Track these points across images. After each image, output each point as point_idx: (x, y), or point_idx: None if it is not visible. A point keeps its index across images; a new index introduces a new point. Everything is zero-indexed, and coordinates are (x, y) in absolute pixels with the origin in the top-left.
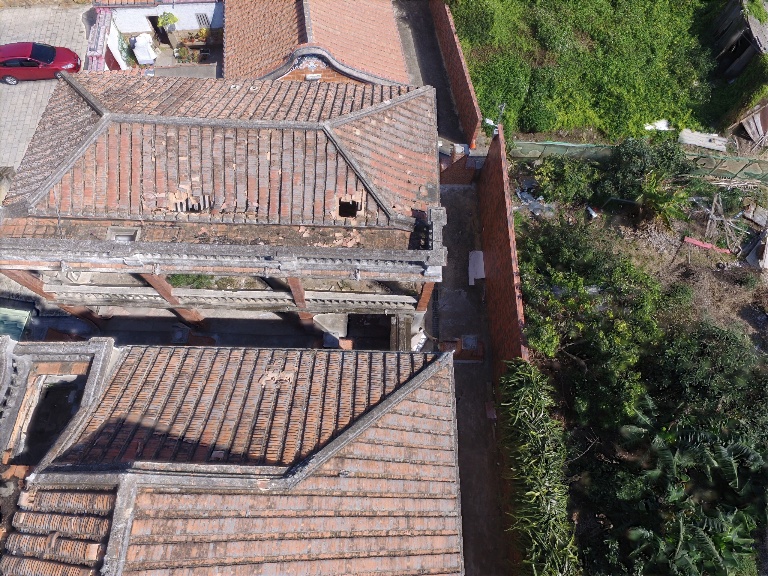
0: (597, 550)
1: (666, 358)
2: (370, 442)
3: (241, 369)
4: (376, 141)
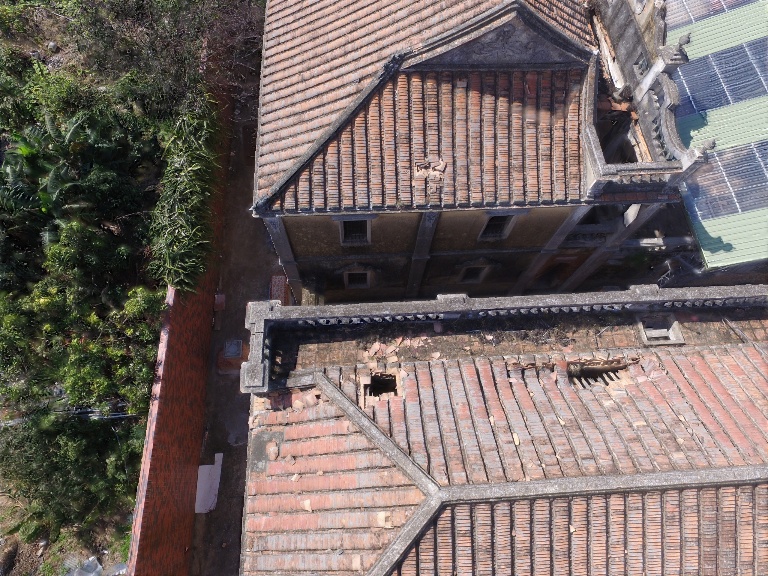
0: (148, 156)
1: (3, 275)
2: (335, 113)
3: (467, 178)
4: (349, 516)
